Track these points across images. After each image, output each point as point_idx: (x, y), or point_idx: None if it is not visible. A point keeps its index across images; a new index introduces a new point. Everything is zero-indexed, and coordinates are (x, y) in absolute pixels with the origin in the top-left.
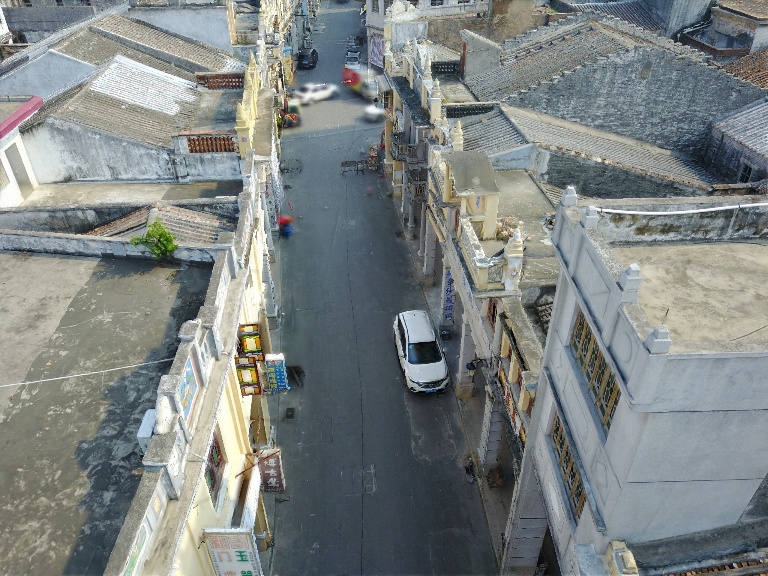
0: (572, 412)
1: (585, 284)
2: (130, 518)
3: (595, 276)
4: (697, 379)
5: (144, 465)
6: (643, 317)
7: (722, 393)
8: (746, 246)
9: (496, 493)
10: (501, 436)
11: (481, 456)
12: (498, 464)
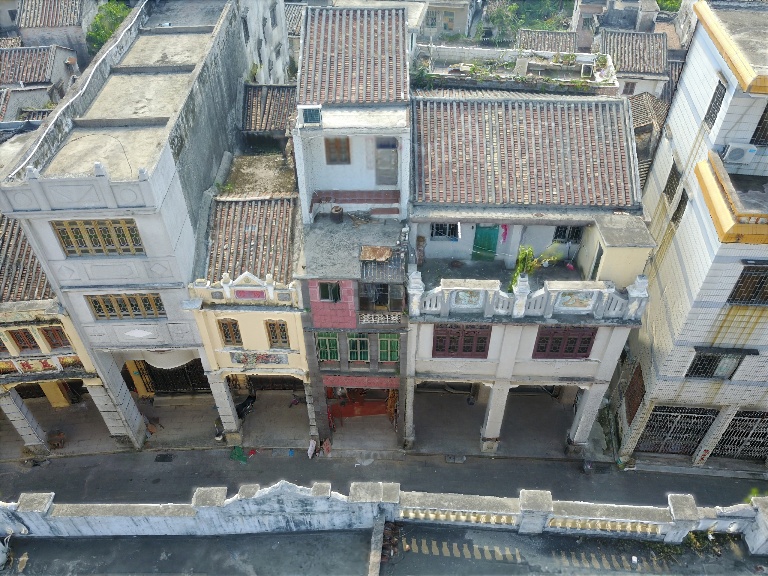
0: (109, 276)
1: (67, 202)
2: (94, 512)
3: (74, 190)
4: (158, 181)
5: (17, 563)
6: (122, 177)
7: (164, 182)
8: (64, 149)
9: (69, 444)
10: (31, 413)
11: (34, 443)
12: (47, 434)
